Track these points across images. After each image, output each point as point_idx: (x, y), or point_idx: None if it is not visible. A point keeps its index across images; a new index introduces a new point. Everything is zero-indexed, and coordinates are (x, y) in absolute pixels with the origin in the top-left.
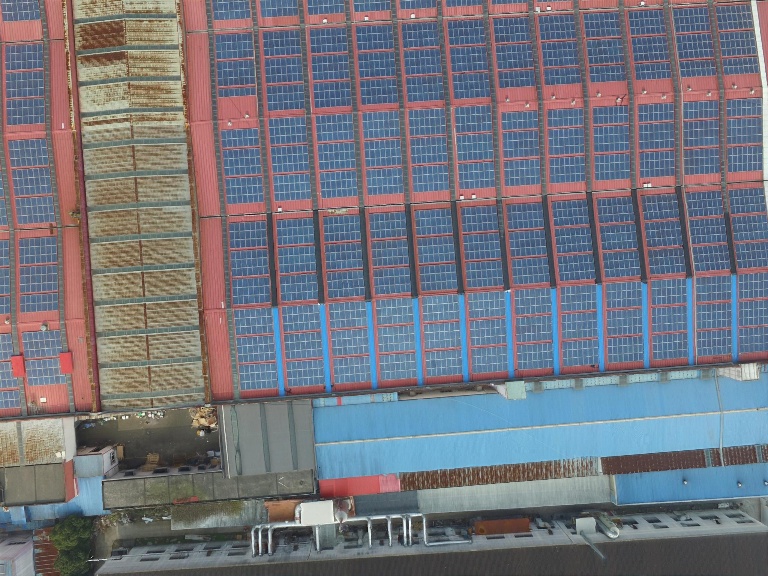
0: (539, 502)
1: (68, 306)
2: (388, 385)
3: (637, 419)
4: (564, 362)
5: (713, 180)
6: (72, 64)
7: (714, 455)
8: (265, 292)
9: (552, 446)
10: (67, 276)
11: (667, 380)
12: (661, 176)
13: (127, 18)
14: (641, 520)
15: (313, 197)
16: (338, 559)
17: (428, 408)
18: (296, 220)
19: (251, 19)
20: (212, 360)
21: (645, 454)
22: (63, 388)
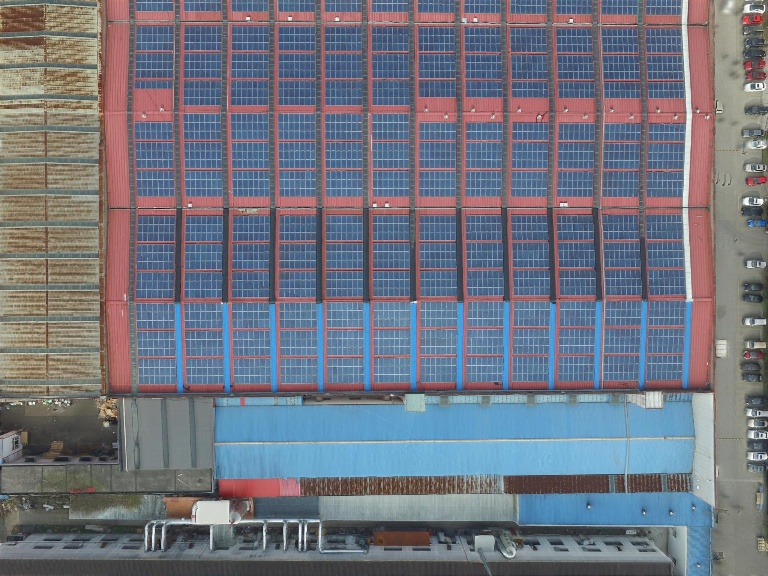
0: (441, 516)
1: None
2: (288, 389)
3: (542, 440)
4: (467, 377)
5: (631, 204)
6: None
7: (619, 481)
8: (169, 287)
9: (454, 461)
10: None
11: (576, 402)
12: (578, 196)
13: (48, 3)
14: (544, 541)
15: (224, 195)
16: (229, 560)
17: (331, 414)
18: (206, 217)
19: (174, 12)
20: (112, 352)
21: (549, 475)
22: None
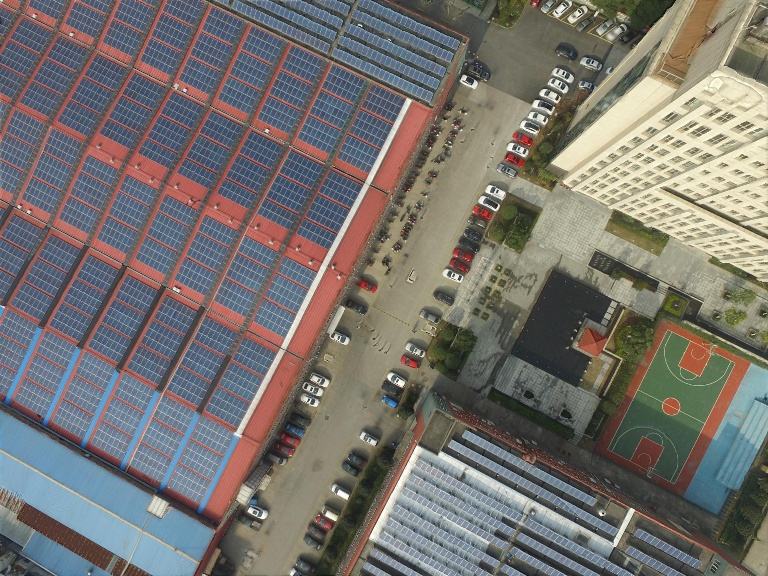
0: None
1: None
2: None
3: (68, 489)
4: (17, 397)
5: (237, 320)
6: None
7: (119, 565)
8: None
9: None
10: None
11: None
12: (193, 289)
13: None
14: None
15: None
16: None
17: None
18: None
19: None
20: None
21: (63, 524)
22: None
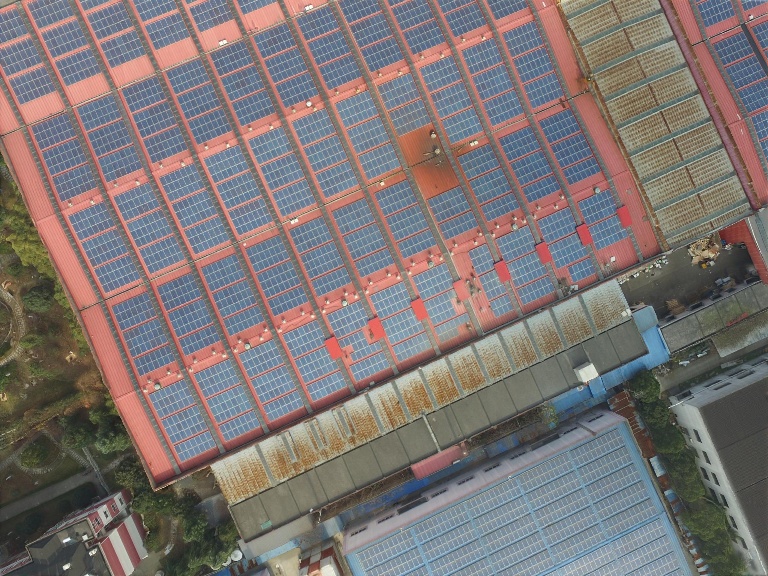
0: None
1: (607, 165)
2: None
3: None
4: None
5: None
6: None
7: None
8: None
9: None
10: (594, 139)
11: None
12: None
13: None
14: None
15: None
16: None
17: None
18: None
19: None
20: None
21: None
22: (626, 242)
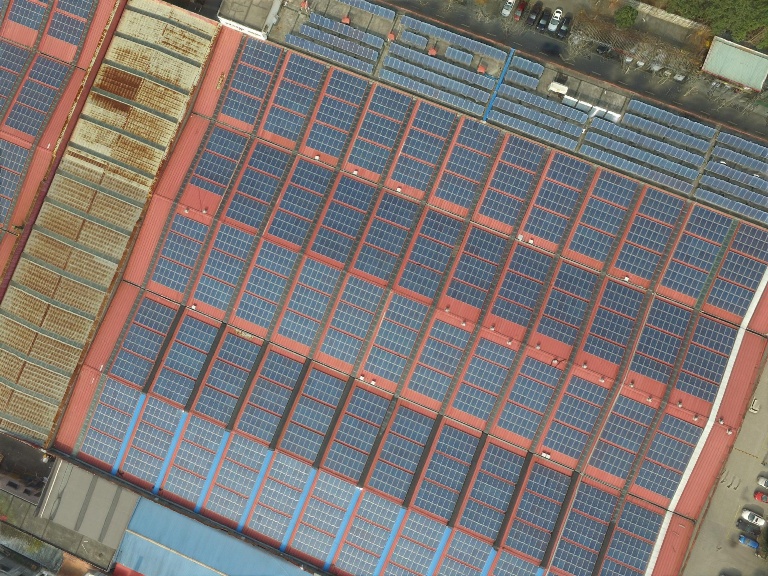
0: None
1: None
2: (210, 515)
3: None
4: None
5: (616, 483)
6: (82, 97)
7: None
8: (143, 375)
9: None
10: None
11: None
12: (564, 453)
13: (147, 78)
14: None
15: (228, 310)
16: None
17: (243, 550)
18: (203, 324)
19: (253, 126)
20: (69, 411)
21: None
22: None
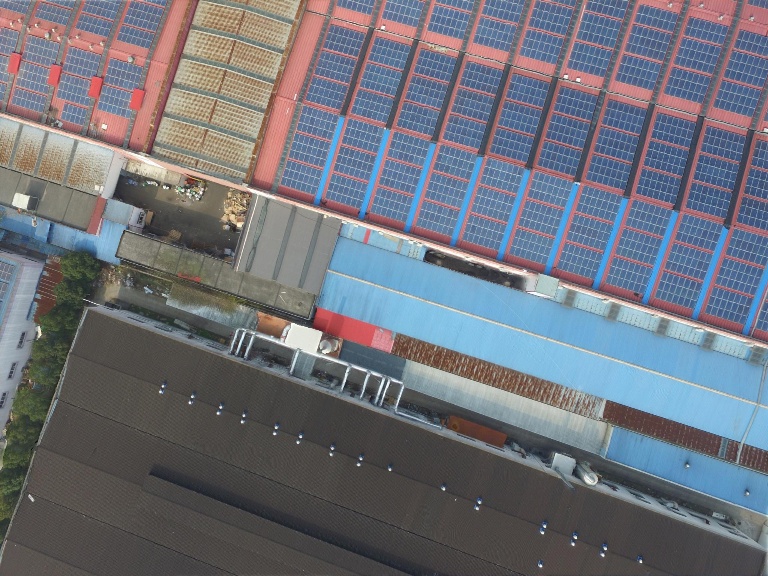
0: (524, 424)
1: (159, 49)
2: (421, 233)
3: (662, 374)
4: (608, 278)
5: None
6: None
7: (732, 447)
8: (339, 99)
9: (560, 367)
10: (168, 22)
11: (710, 348)
12: None
13: None
14: (623, 489)
15: (419, 26)
16: (307, 387)
17: (450, 279)
18: (394, 43)
19: None
20: (265, 146)
21: (656, 416)
22: (125, 122)
